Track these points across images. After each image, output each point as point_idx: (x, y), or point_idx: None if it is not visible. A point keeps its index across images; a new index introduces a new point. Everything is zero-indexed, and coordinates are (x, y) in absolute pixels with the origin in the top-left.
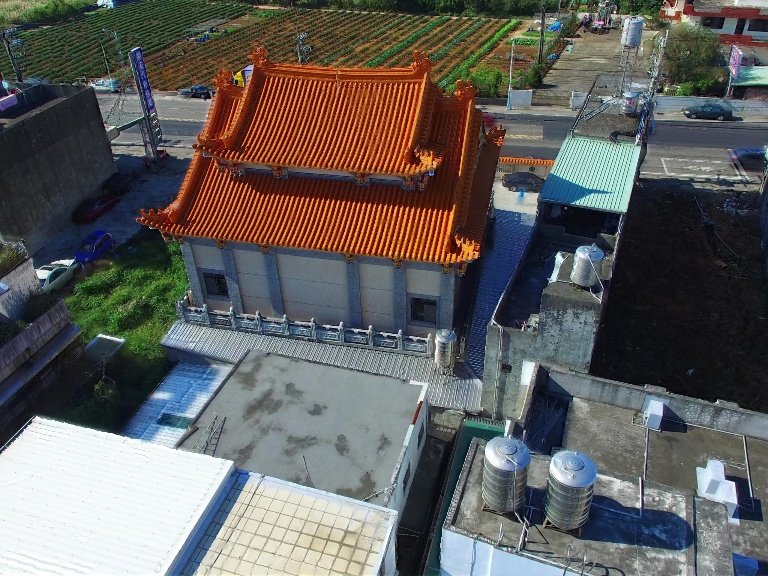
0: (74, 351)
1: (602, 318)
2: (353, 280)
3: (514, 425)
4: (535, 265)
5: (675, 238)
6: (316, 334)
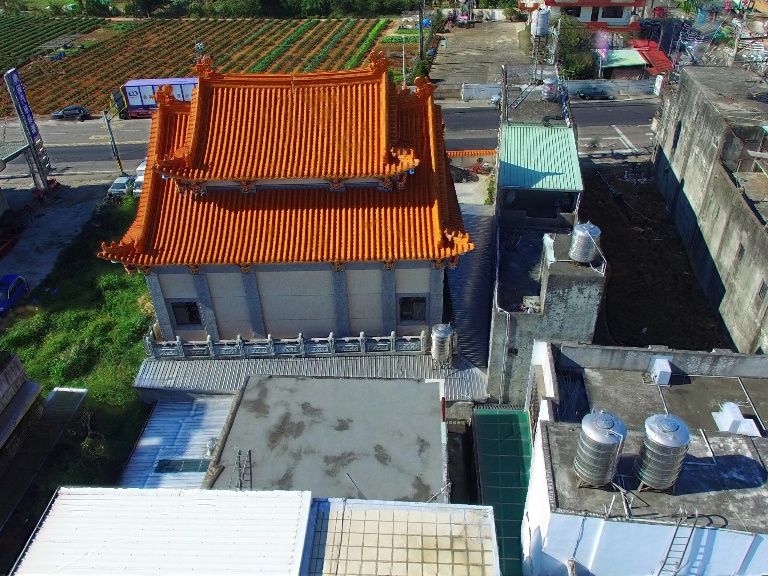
0: (36, 411)
1: (605, 290)
2: (340, 288)
3: (551, 404)
4: (509, 250)
5: (593, 211)
6: (304, 349)
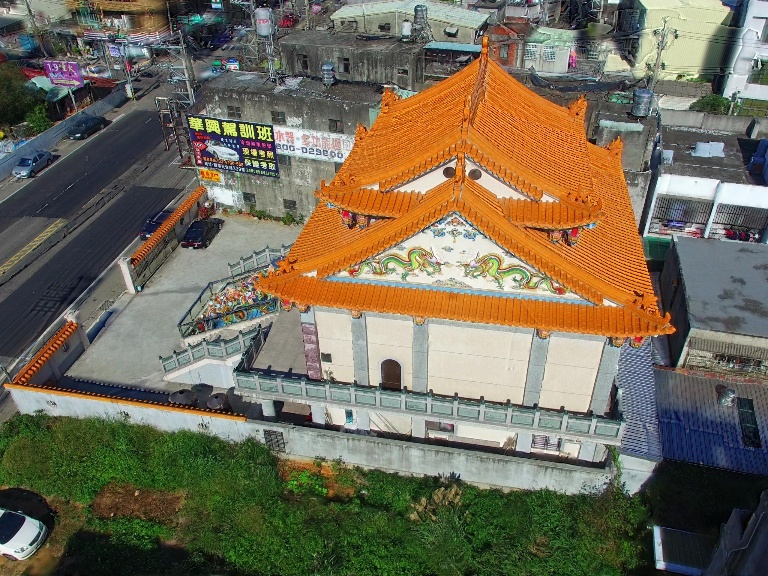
0: None
1: None
2: None
3: None
4: None
5: None
6: None
